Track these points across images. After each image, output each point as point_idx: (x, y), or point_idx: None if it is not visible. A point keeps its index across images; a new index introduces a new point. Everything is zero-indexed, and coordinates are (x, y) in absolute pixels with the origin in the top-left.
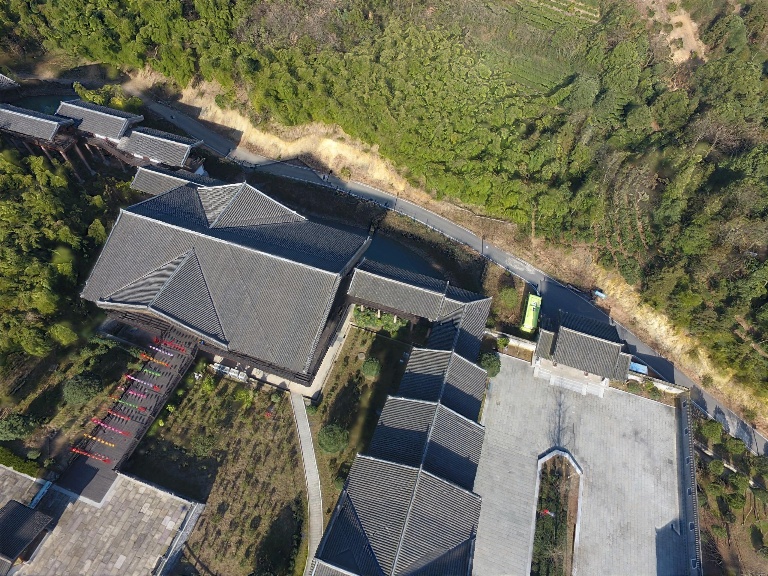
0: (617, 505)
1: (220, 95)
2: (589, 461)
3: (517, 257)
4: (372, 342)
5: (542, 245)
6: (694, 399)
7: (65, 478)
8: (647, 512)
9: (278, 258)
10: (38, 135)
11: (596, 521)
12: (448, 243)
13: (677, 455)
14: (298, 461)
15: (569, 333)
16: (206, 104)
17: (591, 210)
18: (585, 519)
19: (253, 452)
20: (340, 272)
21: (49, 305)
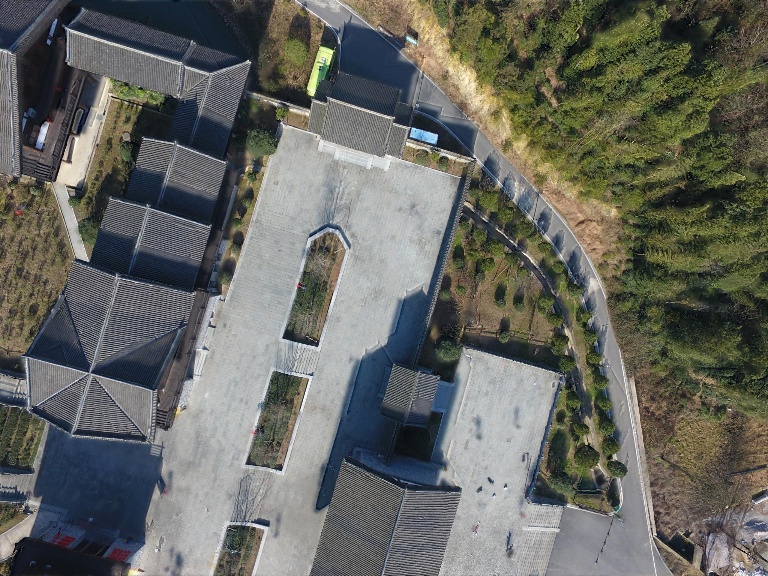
0: (376, 274)
1: None
2: (359, 236)
3: None
4: (136, 119)
5: None
6: (489, 166)
7: None
8: (403, 278)
9: None
10: None
11: (354, 288)
12: None
13: (447, 226)
14: (68, 253)
15: (337, 105)
16: None
17: None
18: (344, 287)
19: (20, 247)
20: (11, 47)
21: None
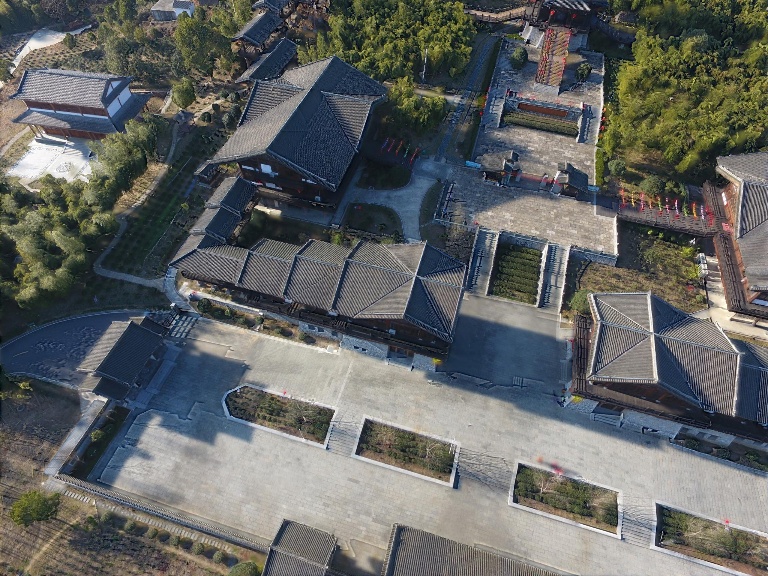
0: None
1: None
2: None
3: None
4: None
5: None
6: None
7: (601, 196)
8: None
9: None
10: None
11: None
12: None
13: None
14: None
15: None
16: None
17: None
18: None
19: (656, 289)
20: None
21: (701, 147)
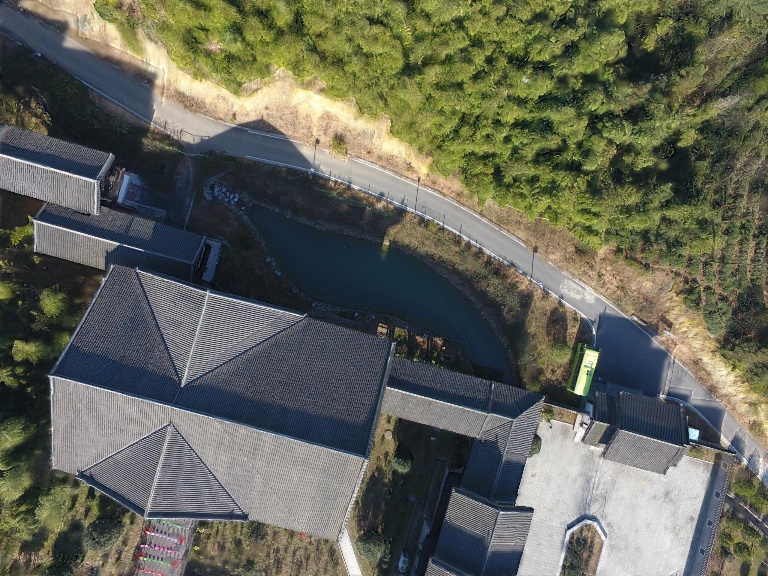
0: (632, 562)
1: (101, 3)
2: (615, 525)
3: (575, 278)
4: None
5: (611, 257)
6: (735, 444)
7: None
8: (658, 566)
9: (285, 438)
10: None
11: None
12: (489, 269)
13: (700, 512)
14: (338, 559)
15: (627, 434)
16: (82, 8)
17: (695, 243)
18: None
19: (294, 558)
20: (367, 453)
21: (21, 482)
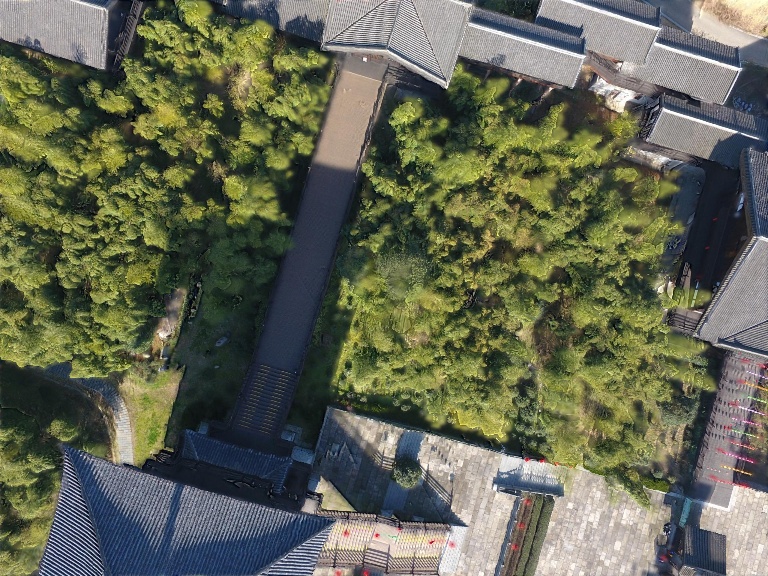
0: None
1: None
2: None
3: None
4: None
5: None
6: None
7: (692, 491)
8: None
9: None
10: (552, 78)
11: None
12: None
13: None
14: None
15: None
16: None
17: None
18: None
19: None
20: None
21: (663, 349)
